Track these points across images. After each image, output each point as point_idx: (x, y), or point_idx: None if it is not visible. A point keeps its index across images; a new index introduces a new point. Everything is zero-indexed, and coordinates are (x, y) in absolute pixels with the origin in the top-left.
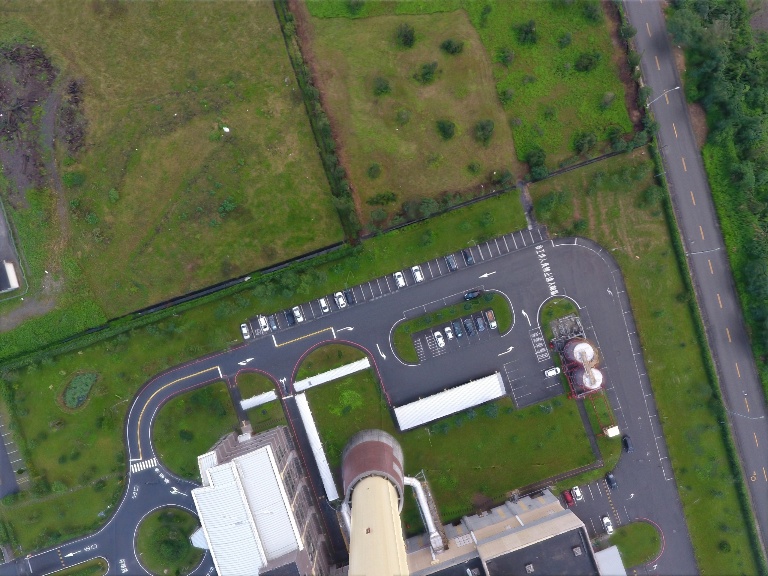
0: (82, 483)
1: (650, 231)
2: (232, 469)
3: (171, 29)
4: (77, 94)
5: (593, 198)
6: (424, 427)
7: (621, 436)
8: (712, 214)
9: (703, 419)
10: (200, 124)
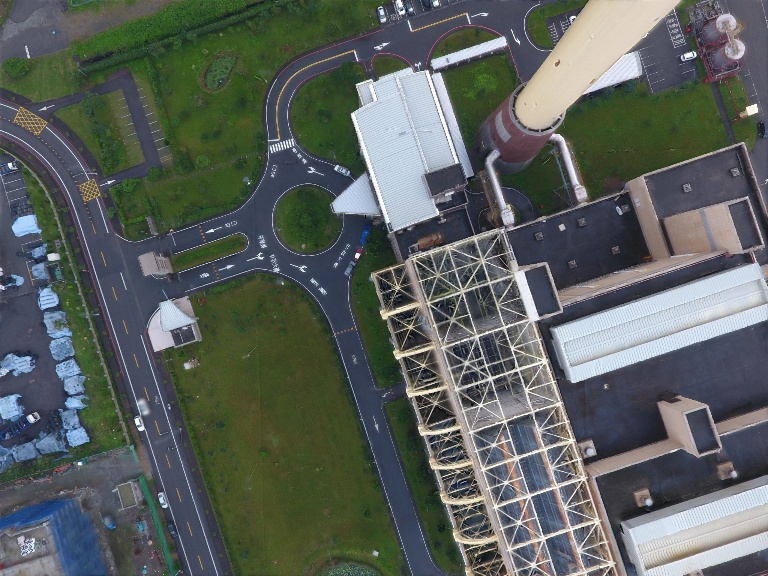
0: (226, 153)
1: None
2: (396, 80)
3: None
4: None
5: None
6: None
7: (757, 122)
8: None
9: None
10: None
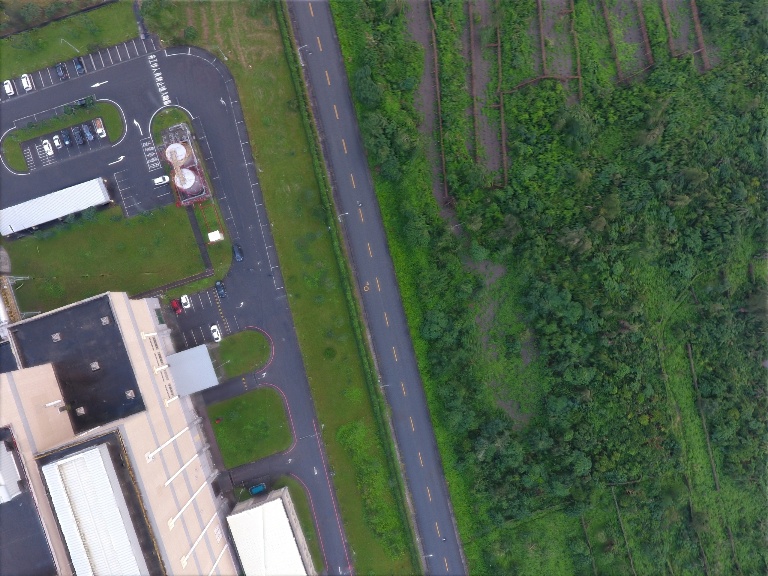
0: None
1: (262, 40)
2: None
3: None
4: None
5: (207, 8)
6: (32, 235)
7: (232, 245)
8: (330, 25)
9: (313, 228)
10: None
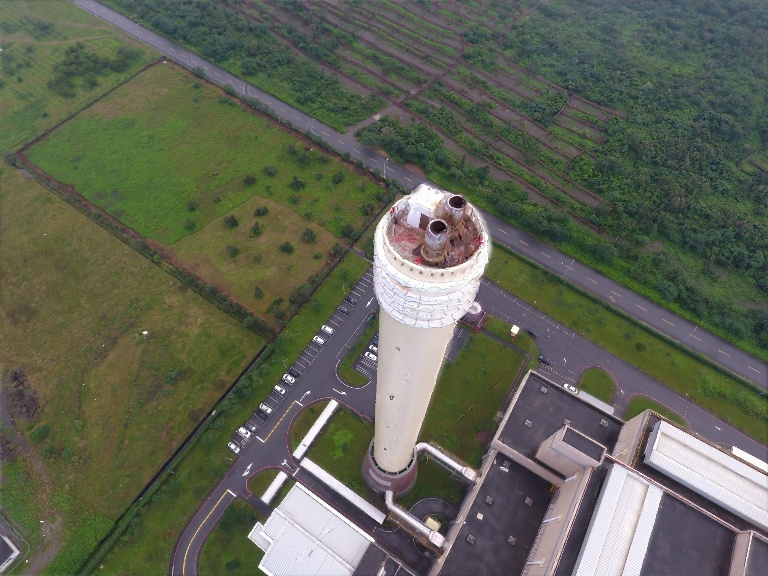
0: None
1: None
2: (278, 513)
3: (76, 303)
4: (20, 379)
5: None
6: None
7: (524, 332)
8: None
9: (555, 290)
10: (124, 341)
